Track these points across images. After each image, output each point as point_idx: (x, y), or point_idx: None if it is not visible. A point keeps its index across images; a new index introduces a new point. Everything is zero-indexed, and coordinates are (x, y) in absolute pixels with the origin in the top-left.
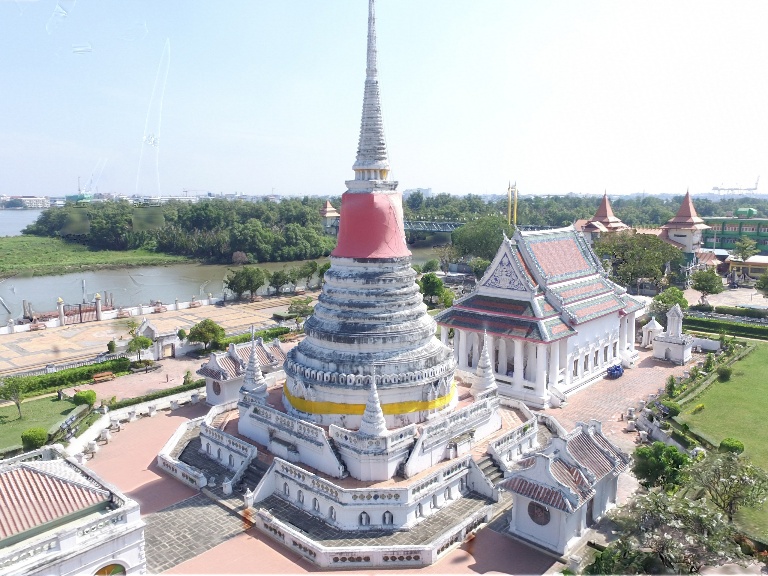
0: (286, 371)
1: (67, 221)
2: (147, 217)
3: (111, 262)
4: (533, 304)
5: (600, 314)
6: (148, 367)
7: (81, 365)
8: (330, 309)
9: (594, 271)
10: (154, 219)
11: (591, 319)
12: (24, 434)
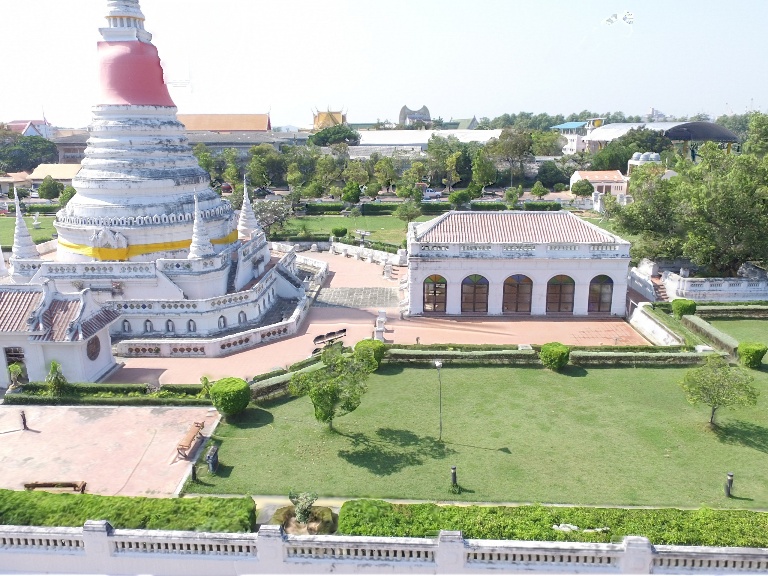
0: (213, 219)
1: None
2: None
3: None
4: None
5: None
6: None
7: (3, 542)
8: (190, 156)
9: None
10: None
11: None
12: (382, 343)
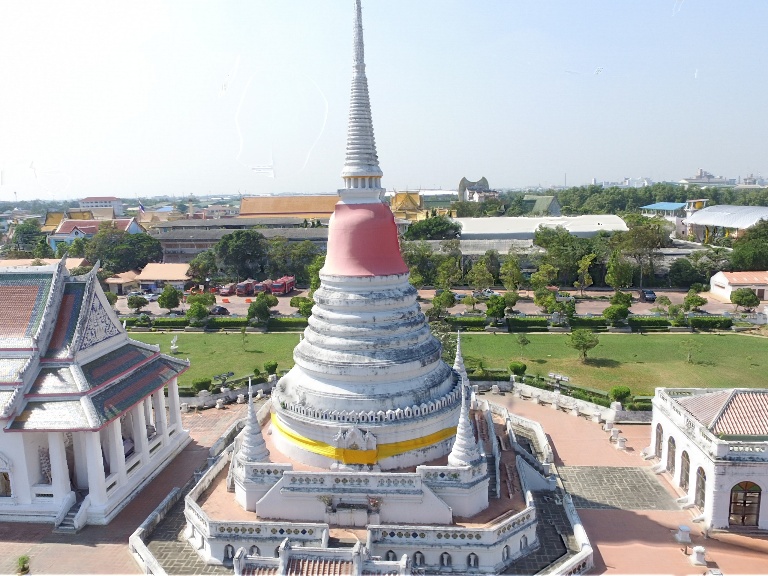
0: None
1: None
2: None
3: None
4: (138, 343)
5: None
6: None
7: None
8: None
9: None
10: None
11: None
12: None
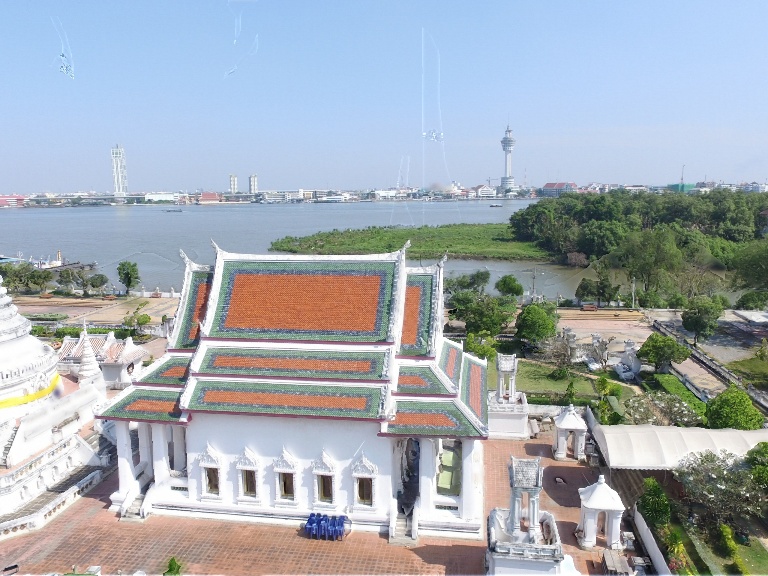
0: None
1: (393, 213)
2: (441, 211)
3: (474, 252)
4: None
5: (268, 410)
6: (137, 341)
7: (112, 328)
8: None
9: (376, 338)
10: (450, 213)
11: (231, 411)
12: None
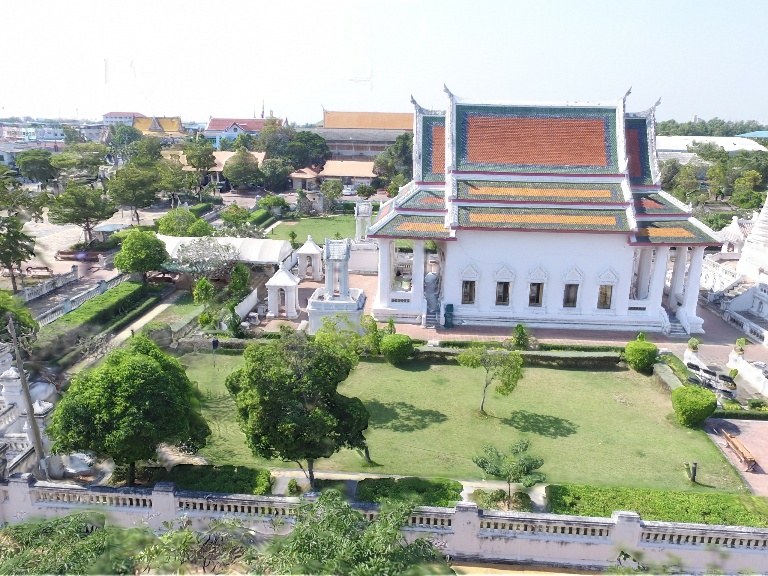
0: None
1: None
2: None
3: None
4: None
5: None
6: None
7: None
8: None
9: None
10: None
11: None
12: None
